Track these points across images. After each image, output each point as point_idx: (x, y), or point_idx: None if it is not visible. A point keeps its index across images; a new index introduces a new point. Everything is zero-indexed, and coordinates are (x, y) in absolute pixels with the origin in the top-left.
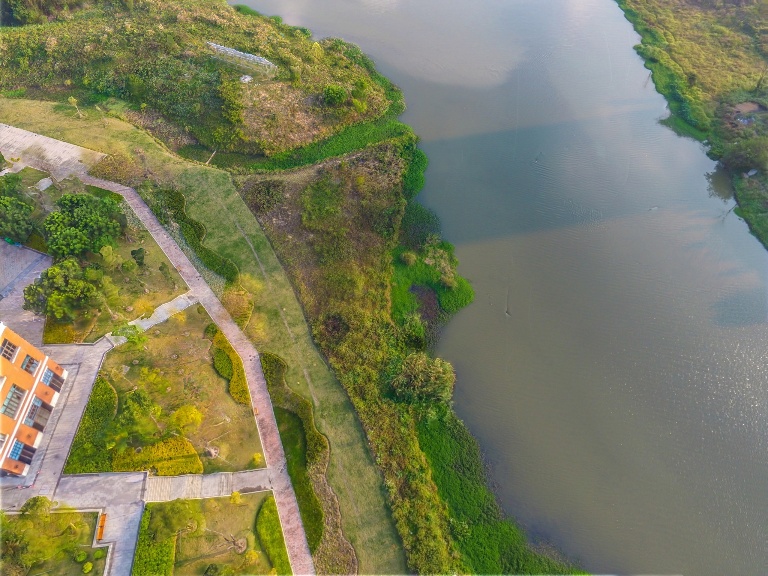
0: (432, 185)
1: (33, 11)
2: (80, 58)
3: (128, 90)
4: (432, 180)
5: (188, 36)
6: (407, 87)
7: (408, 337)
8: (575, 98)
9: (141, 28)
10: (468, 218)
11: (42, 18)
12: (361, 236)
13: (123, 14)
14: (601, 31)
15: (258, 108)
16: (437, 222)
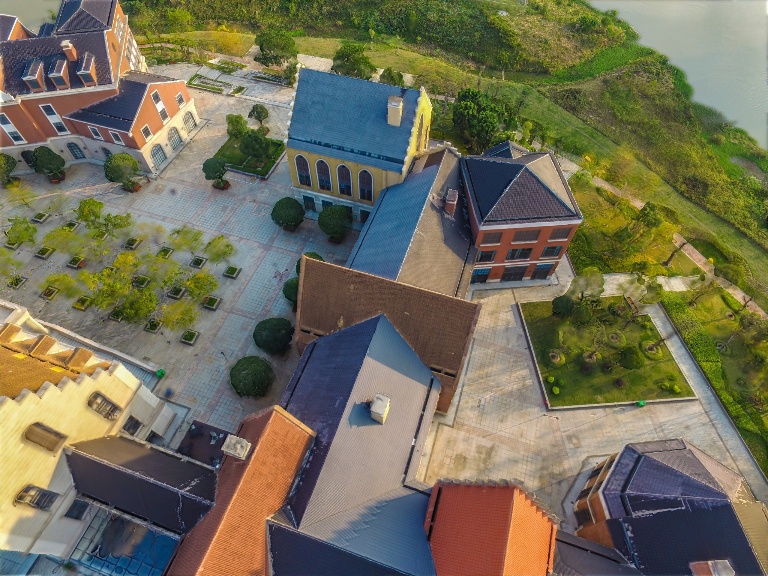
0: (699, 89)
1: None
2: (342, 2)
3: None
4: (697, 86)
5: None
6: (629, 19)
7: (754, 190)
8: None
9: None
10: (742, 112)
11: None
12: (671, 125)
13: None
14: None
15: (530, 35)
16: (721, 115)
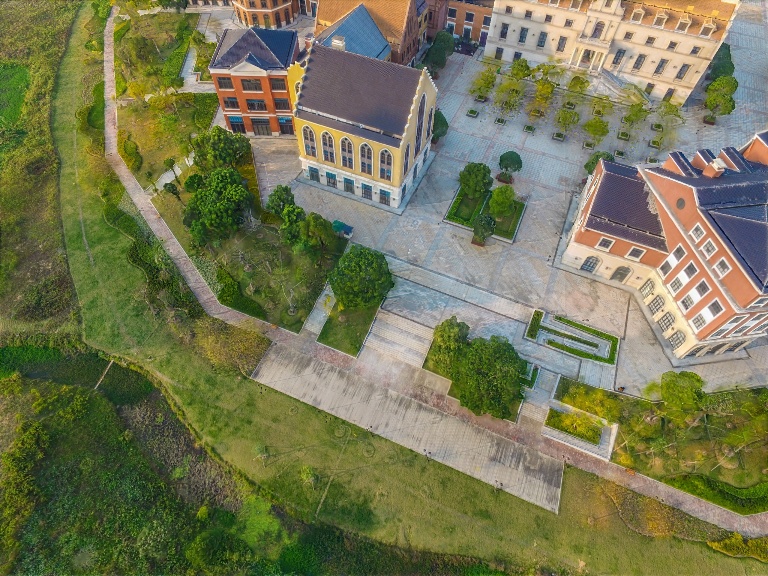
0: None
1: None
2: None
3: None
4: None
5: None
6: None
7: None
8: None
9: None
10: None
11: None
12: None
13: None
14: None
15: None
16: None
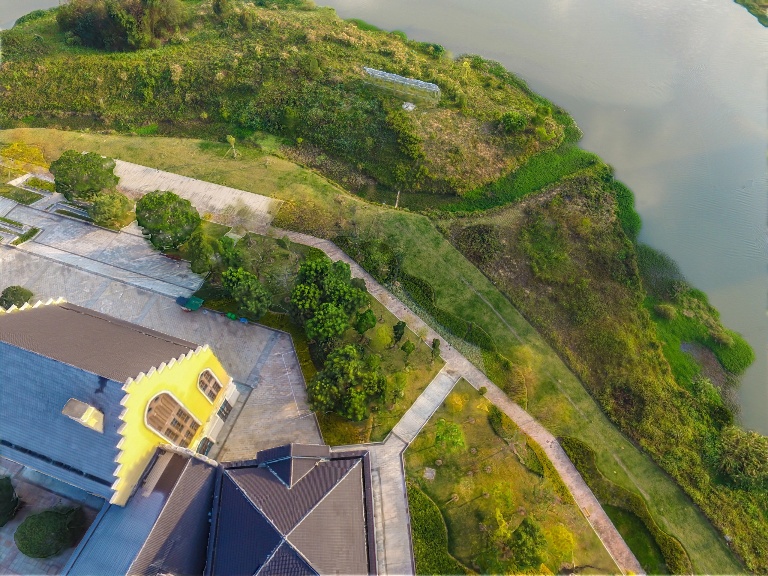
0: (649, 222)
1: (146, 34)
2: (211, 87)
3: (278, 123)
4: (647, 216)
5: (327, 59)
6: (572, 109)
7: (709, 407)
8: (752, 116)
9: (271, 51)
10: (702, 259)
11: (156, 42)
12: (605, 287)
13: (241, 34)
14: (744, 39)
15: (437, 141)
16: (675, 266)
